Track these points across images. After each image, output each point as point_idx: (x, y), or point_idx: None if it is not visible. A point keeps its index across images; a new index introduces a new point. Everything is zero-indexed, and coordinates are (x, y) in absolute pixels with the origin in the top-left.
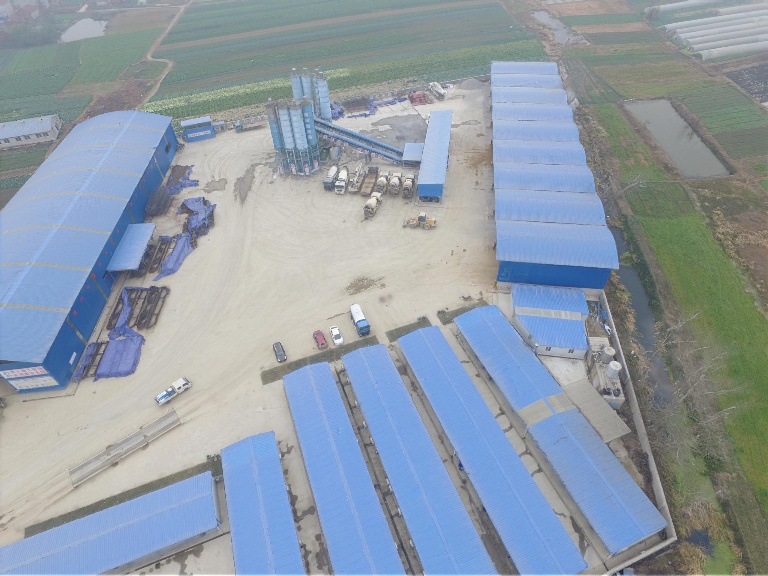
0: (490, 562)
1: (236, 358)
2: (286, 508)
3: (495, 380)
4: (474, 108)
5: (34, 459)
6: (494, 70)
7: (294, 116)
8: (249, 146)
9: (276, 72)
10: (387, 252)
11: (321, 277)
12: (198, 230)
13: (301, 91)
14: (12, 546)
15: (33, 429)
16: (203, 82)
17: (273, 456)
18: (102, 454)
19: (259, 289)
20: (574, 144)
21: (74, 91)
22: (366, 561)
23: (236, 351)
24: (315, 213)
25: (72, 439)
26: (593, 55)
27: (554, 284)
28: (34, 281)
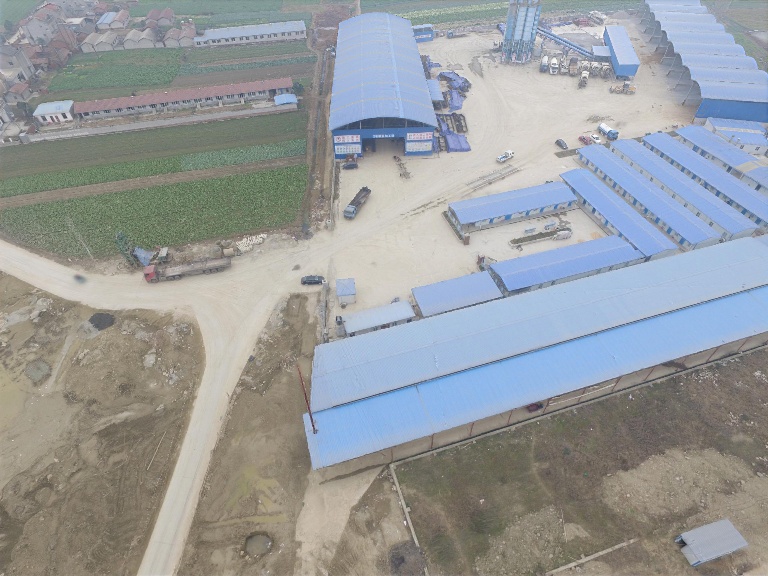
0: (742, 214)
1: (533, 147)
2: (615, 194)
3: (715, 155)
4: (630, 30)
5: (438, 180)
6: (648, 1)
7: (531, 12)
8: (464, 46)
9: (453, 2)
10: (606, 104)
11: (566, 114)
12: (463, 88)
13: (516, 2)
14: (467, 200)
15: (426, 170)
16: (396, 7)
17: (594, 177)
18: (480, 179)
19: (526, 118)
20: (733, 44)
21: (292, 9)
22: (674, 210)
23: (531, 144)
24: (540, 84)
25: (454, 174)
26: (714, 1)
27: (736, 119)
28: (406, 91)
